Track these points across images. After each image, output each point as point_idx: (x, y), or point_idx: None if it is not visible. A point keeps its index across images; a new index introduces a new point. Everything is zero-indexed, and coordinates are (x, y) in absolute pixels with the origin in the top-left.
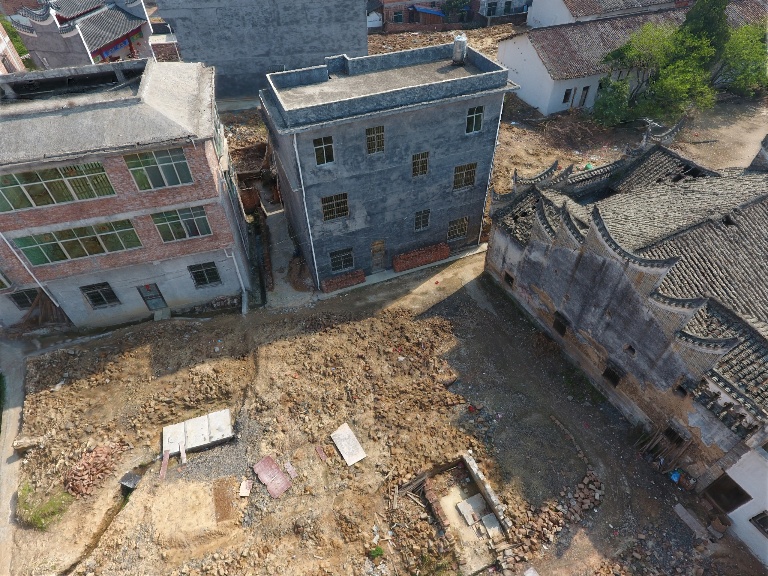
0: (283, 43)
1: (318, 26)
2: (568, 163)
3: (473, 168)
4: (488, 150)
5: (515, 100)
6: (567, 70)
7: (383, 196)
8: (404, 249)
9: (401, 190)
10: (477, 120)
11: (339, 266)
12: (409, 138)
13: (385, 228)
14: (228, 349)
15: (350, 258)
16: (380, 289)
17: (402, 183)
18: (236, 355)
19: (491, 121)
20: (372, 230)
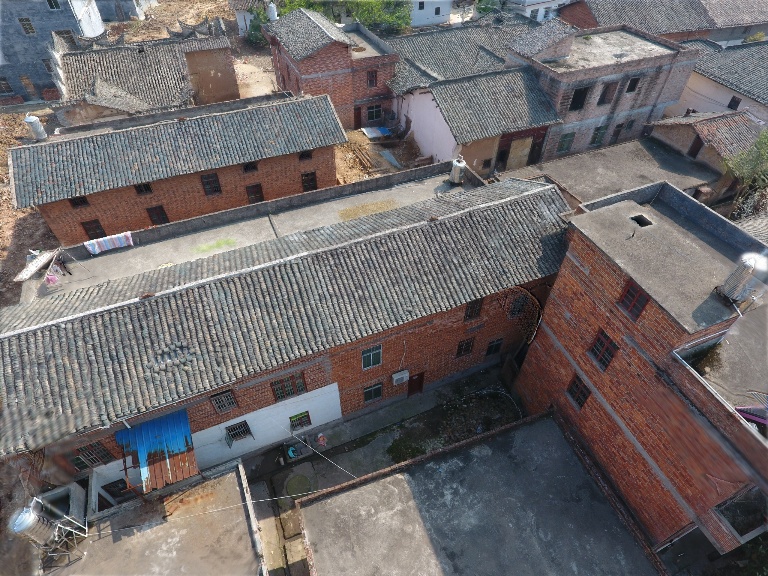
0: None
1: None
2: None
3: (70, 34)
4: (73, 22)
5: (235, 30)
6: (242, 4)
7: (10, 44)
8: (47, 86)
9: (22, 41)
10: (56, 2)
11: (2, 90)
12: (9, 7)
13: (23, 67)
14: None
15: (8, 86)
16: (29, 107)
17: (20, 37)
18: None
19: (64, 3)
20: (14, 67)
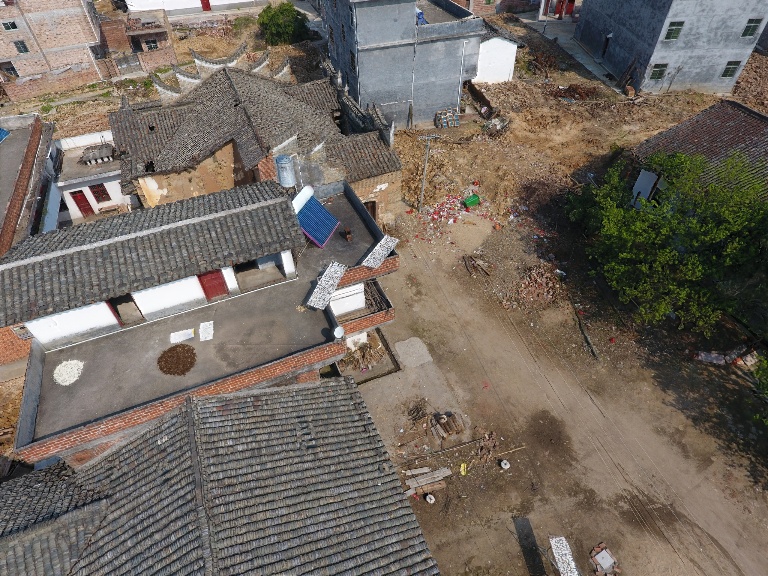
0: (621, 11)
1: (642, 5)
2: (491, 193)
3: None
4: None
5: None
6: None
7: None
8: None
9: None
10: None
11: None
12: None
13: None
14: (295, 70)
15: None
16: None
17: None
18: (292, 73)
19: None
20: None
